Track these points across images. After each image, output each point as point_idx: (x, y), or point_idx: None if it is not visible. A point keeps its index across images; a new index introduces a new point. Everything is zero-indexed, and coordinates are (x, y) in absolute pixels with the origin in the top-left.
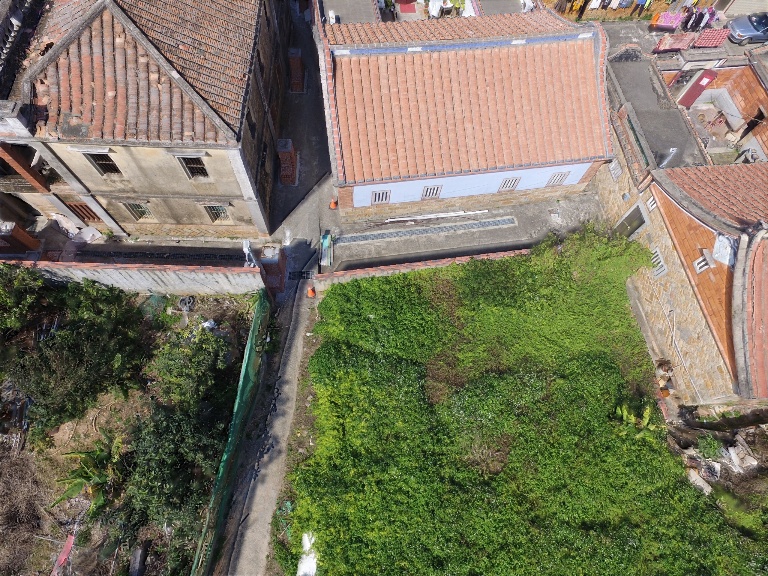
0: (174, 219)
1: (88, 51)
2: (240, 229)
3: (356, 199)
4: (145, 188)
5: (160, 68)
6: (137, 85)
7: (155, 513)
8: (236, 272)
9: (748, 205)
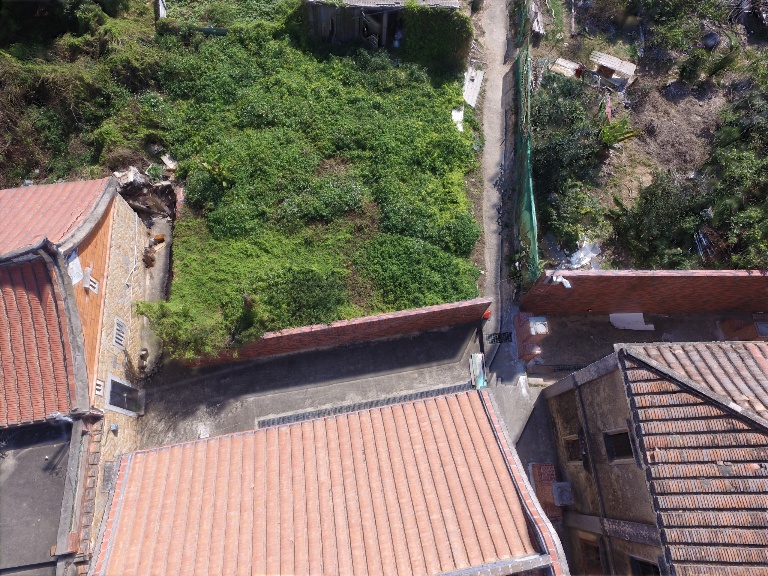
0: None
1: None
2: None
3: None
4: None
5: None
6: None
7: None
8: (567, 271)
9: (6, 330)
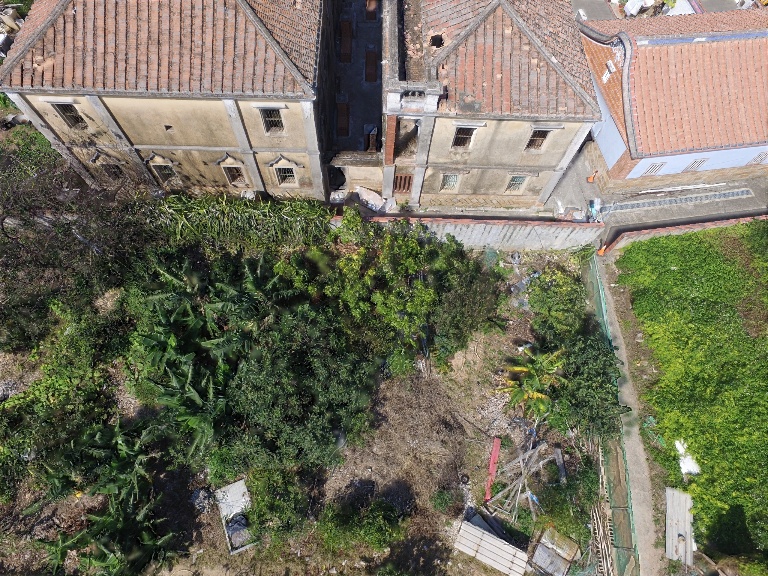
0: (473, 190)
1: (482, 41)
2: (522, 199)
3: (633, 171)
4: (477, 160)
5: (539, 54)
6: (519, 69)
7: (605, 410)
8: (585, 226)
9: None
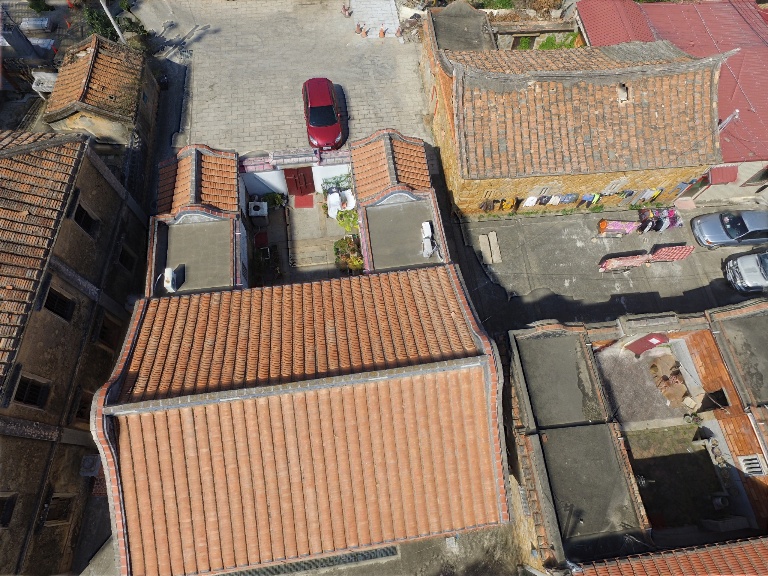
0: None
1: None
2: None
3: None
4: None
5: None
6: None
7: None
8: None
9: None
